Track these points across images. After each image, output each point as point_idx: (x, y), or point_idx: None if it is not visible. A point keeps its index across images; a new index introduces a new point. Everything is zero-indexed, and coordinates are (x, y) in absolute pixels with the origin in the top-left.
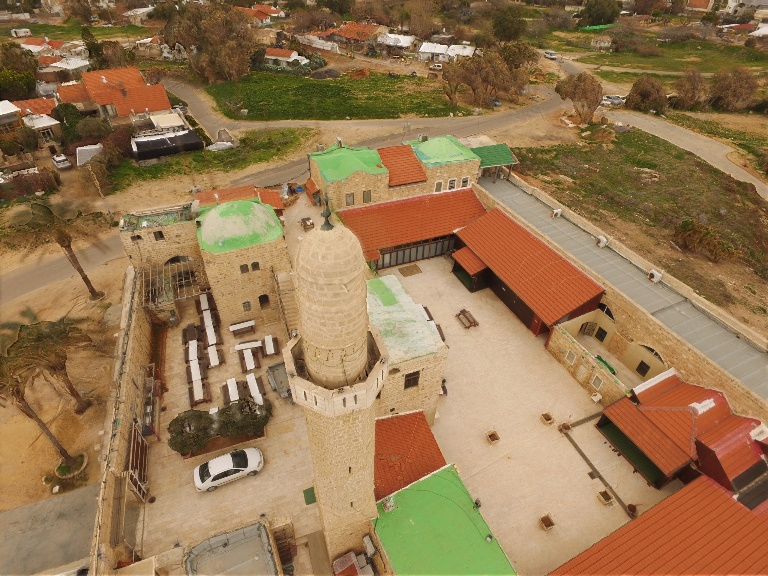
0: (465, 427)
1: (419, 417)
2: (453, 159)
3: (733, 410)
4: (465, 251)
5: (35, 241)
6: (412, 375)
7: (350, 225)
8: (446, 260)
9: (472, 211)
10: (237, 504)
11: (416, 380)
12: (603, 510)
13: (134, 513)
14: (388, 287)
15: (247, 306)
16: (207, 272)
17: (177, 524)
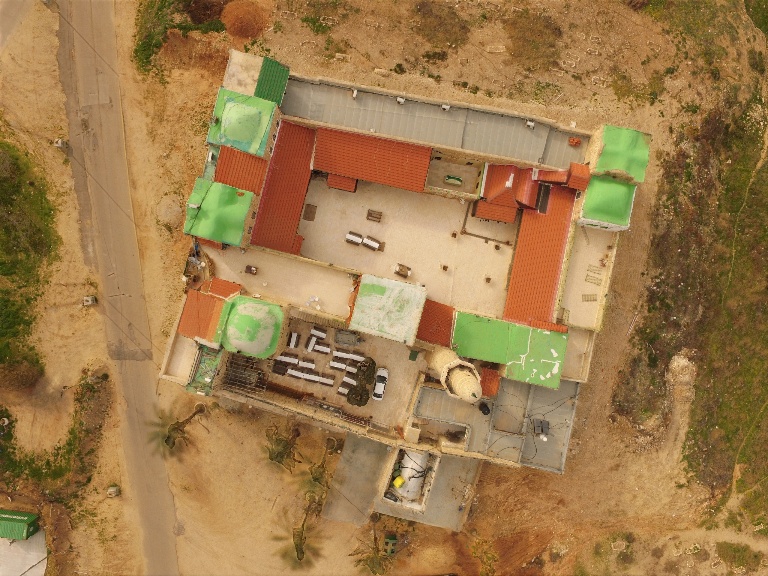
0: (431, 275)
1: None
2: (263, 127)
3: (520, 168)
4: (332, 177)
5: (95, 435)
6: None
7: (266, 240)
8: (316, 181)
9: (302, 139)
10: (396, 387)
11: None
12: (499, 253)
13: (372, 425)
14: (371, 284)
15: None
16: None
17: (388, 411)
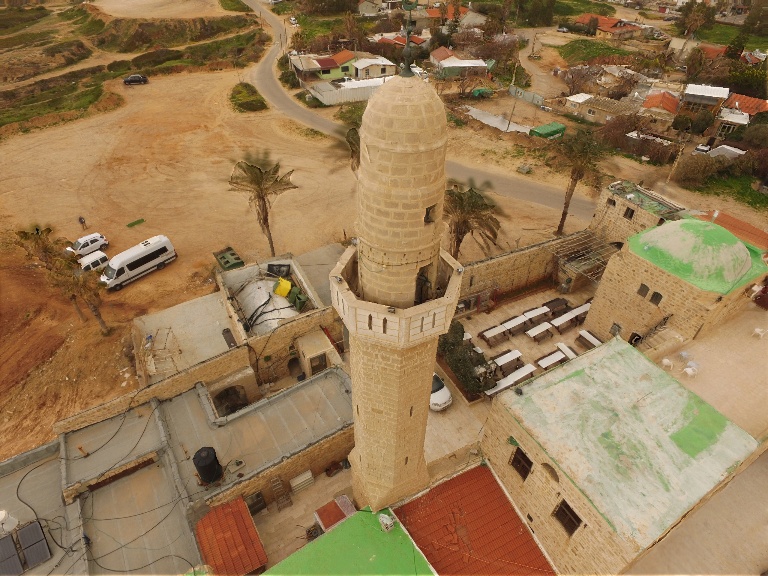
0: None
1: (545, 572)
2: None
3: None
4: None
5: (591, 181)
6: (573, 514)
7: None
8: None
9: None
10: None
11: (572, 527)
12: None
13: None
14: (719, 437)
15: (615, 330)
16: (609, 262)
17: None
